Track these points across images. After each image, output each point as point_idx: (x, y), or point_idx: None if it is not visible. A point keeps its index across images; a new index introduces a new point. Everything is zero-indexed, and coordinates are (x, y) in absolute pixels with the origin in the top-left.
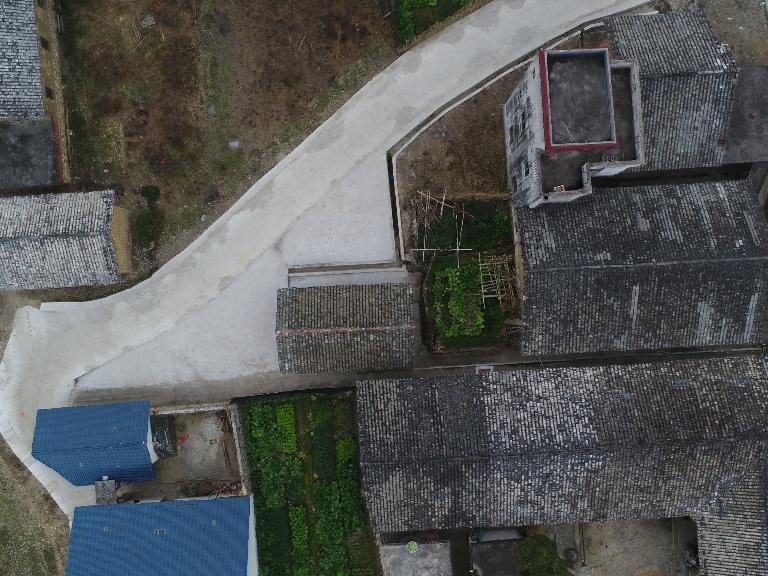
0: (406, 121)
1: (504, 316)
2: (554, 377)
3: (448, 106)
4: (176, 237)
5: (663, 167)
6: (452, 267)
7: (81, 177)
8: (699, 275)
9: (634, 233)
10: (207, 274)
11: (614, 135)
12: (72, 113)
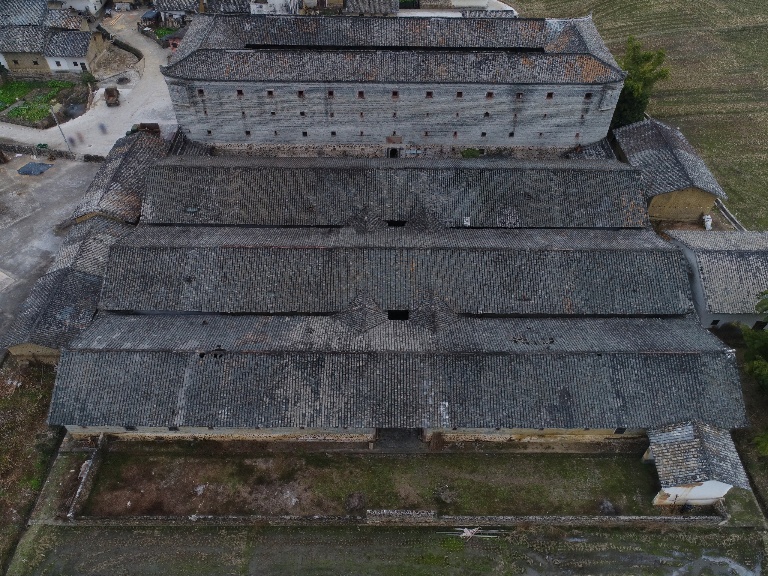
0: None
1: None
2: None
3: None
4: None
5: None
6: None
7: None
8: None
9: None
10: None
11: None
12: None
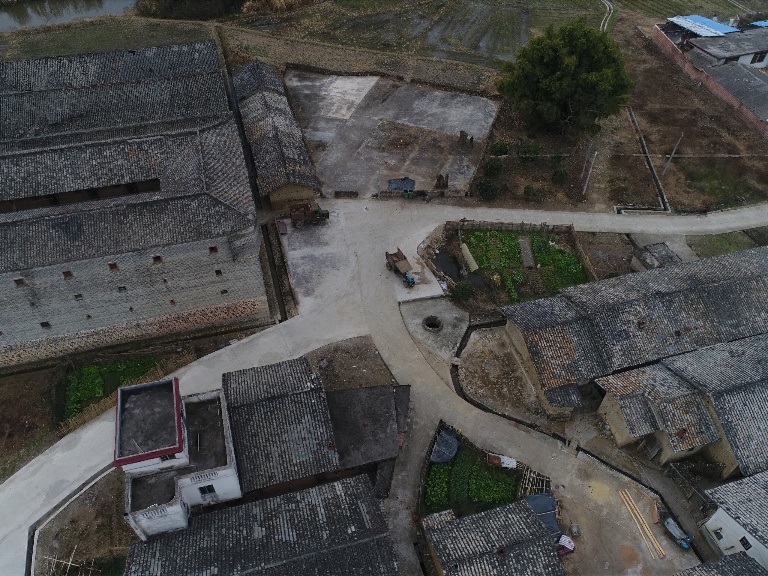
0: (56, 494)
1: None
2: None
3: (102, 473)
4: None
5: (285, 479)
6: None
7: None
8: (315, 571)
9: (247, 543)
10: None
11: (177, 440)
12: None
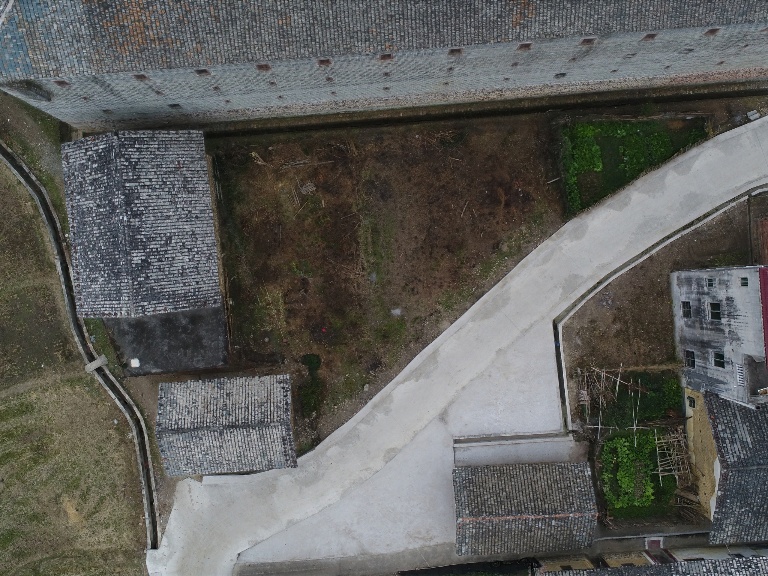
0: (572, 289)
1: (674, 487)
2: (745, 568)
3: (614, 273)
4: (338, 407)
5: None
6: (620, 437)
7: (240, 345)
8: None
9: None
10: (372, 446)
11: None
12: (231, 281)
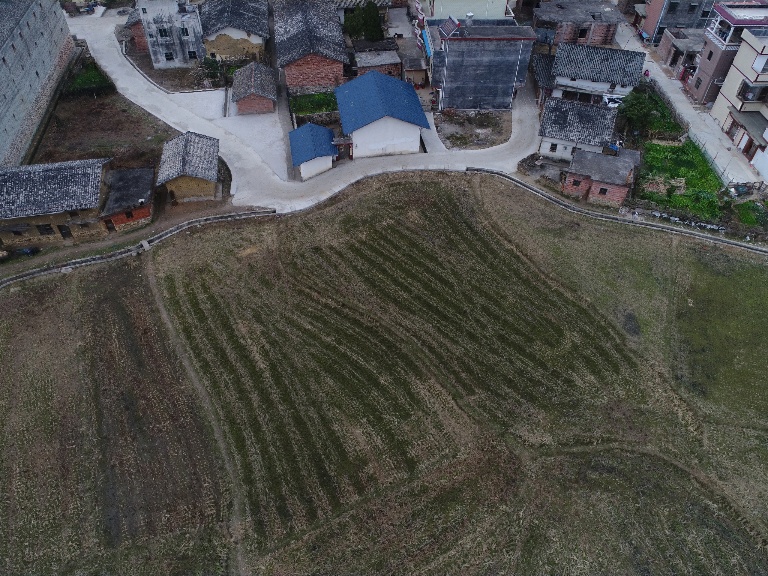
0: None
1: None
2: None
3: None
4: None
5: None
6: None
7: None
8: None
9: None
10: (222, 139)
11: None
12: None
